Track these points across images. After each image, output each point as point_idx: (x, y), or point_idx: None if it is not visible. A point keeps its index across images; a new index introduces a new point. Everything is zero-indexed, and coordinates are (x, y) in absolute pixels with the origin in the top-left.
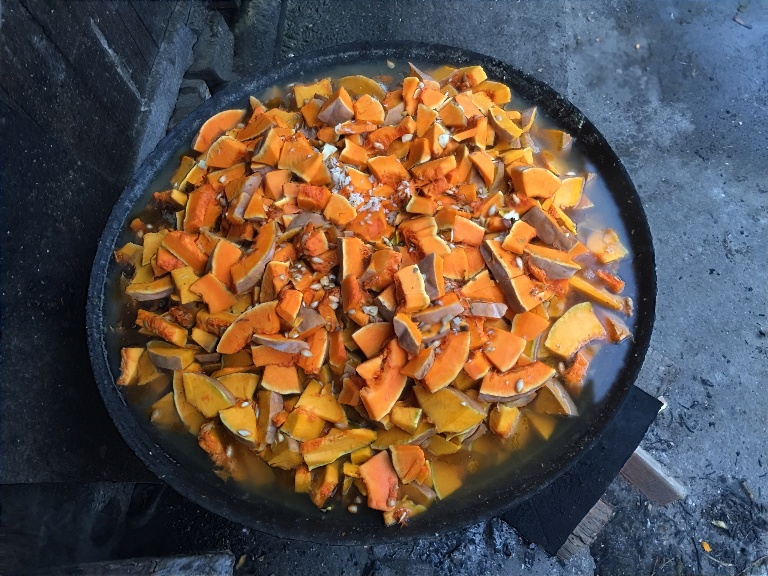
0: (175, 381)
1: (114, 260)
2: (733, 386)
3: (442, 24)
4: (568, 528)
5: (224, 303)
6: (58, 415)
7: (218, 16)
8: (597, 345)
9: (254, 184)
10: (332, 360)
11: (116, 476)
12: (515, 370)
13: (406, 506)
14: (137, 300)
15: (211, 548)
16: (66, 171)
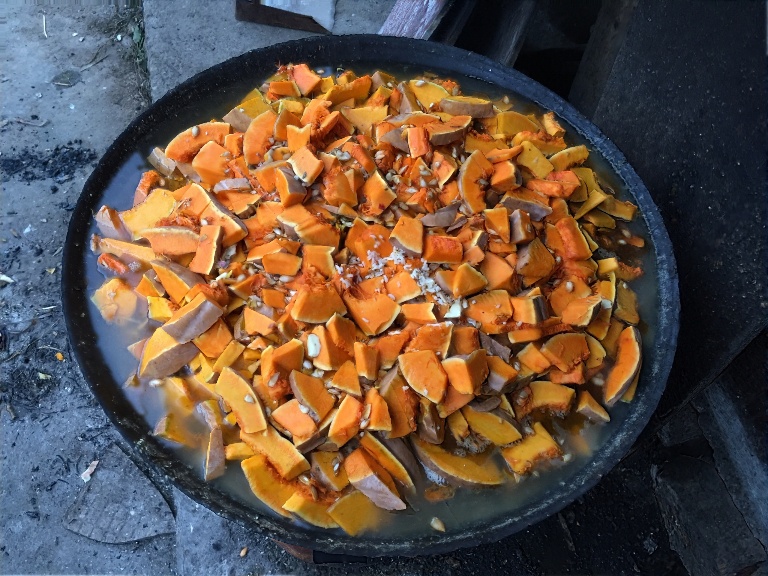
0: None
1: None
2: (4, 519)
3: None
4: None
5: None
6: None
7: None
8: None
9: (521, 261)
10: None
11: None
12: None
13: (280, 77)
14: None
15: None
16: (763, 280)
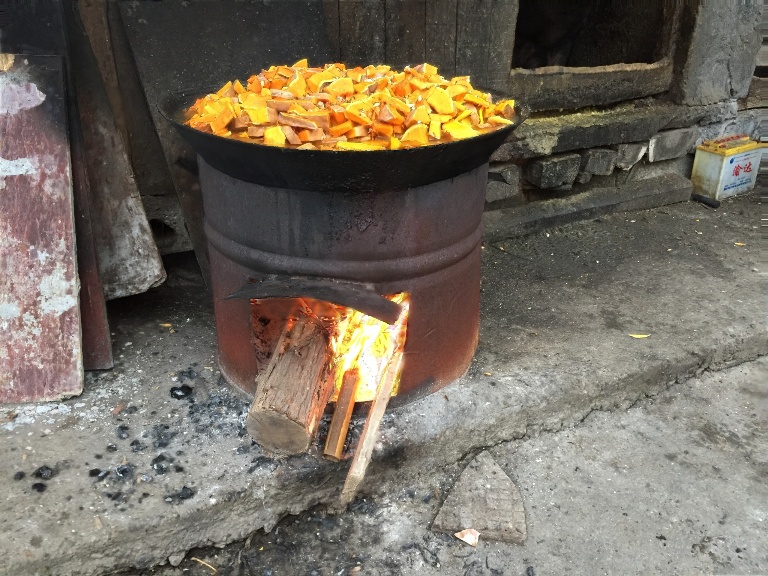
0: None
1: None
2: None
3: (663, 277)
4: None
5: None
6: None
7: (515, 168)
8: None
9: None
10: None
11: (186, 208)
12: None
13: None
14: None
15: (169, 314)
16: None
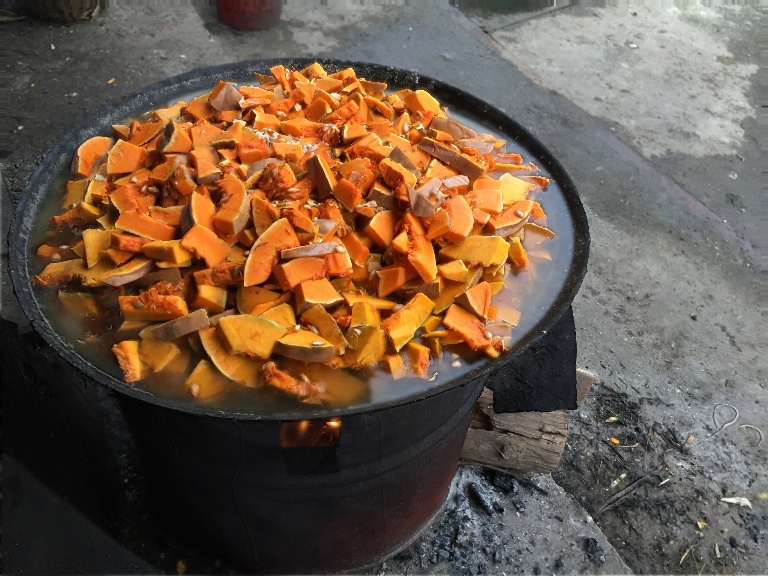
0: (205, 342)
1: (39, 285)
2: None
3: None
4: (572, 382)
5: (219, 254)
6: (1, 523)
7: None
8: (532, 197)
9: (183, 163)
10: (357, 260)
11: None
12: (505, 211)
13: None
14: (113, 286)
15: None
16: None
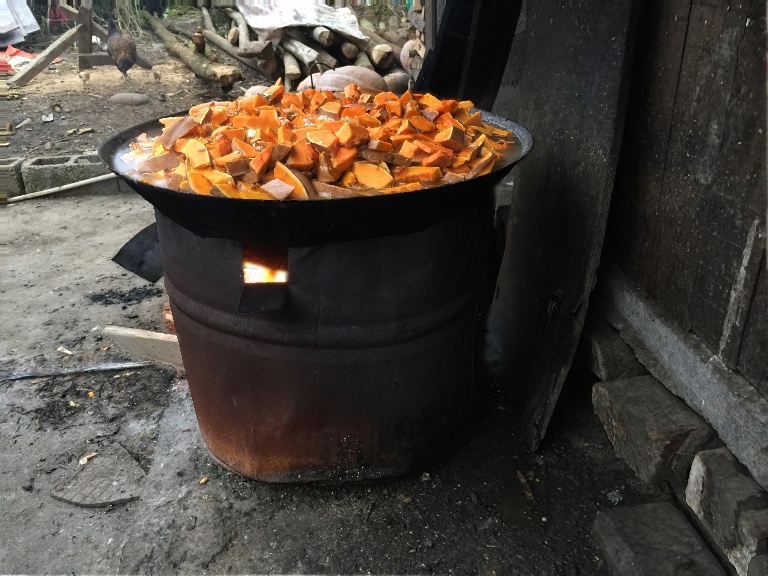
0: None
1: None
2: (2, 491)
3: None
4: None
5: None
6: None
7: None
8: None
9: None
10: None
11: None
12: None
13: None
14: None
15: None
16: None
